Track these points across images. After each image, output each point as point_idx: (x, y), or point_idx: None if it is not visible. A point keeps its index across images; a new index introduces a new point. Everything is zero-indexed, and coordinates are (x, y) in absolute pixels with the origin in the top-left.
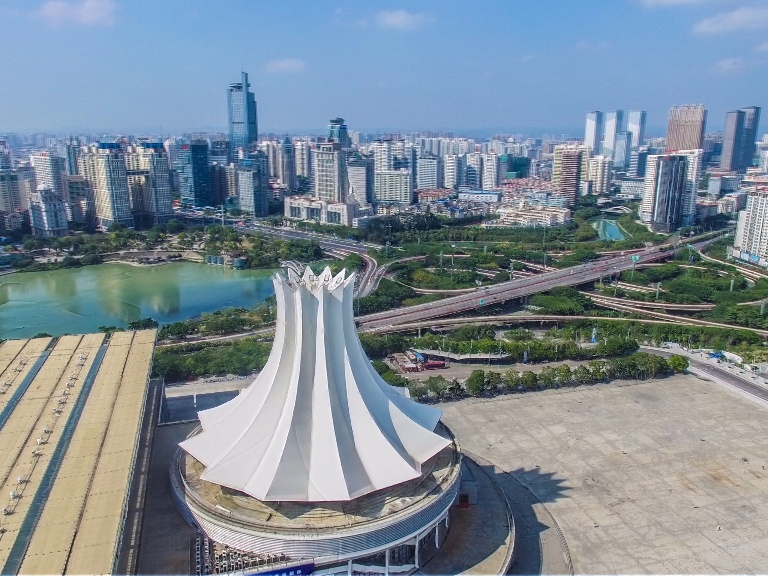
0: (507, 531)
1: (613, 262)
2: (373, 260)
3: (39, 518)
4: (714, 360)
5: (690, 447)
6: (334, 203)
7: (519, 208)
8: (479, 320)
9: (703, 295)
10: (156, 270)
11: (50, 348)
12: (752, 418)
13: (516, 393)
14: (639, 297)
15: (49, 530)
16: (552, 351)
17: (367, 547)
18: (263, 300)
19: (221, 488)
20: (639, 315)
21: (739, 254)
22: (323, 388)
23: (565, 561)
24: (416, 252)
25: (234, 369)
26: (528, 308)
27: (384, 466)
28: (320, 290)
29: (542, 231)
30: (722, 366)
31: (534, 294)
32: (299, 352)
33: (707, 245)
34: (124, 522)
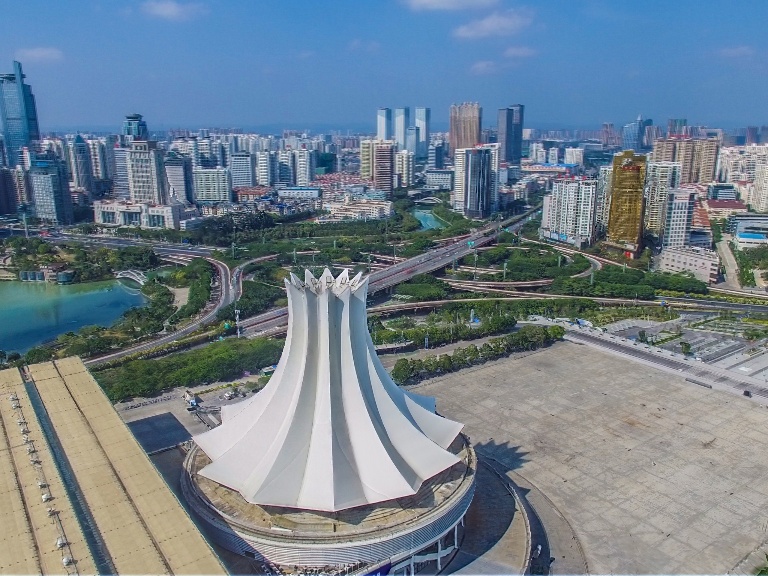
0: (512, 499)
1: (452, 248)
2: (221, 263)
3: None
4: (576, 326)
5: (599, 402)
6: (155, 206)
7: (345, 202)
8: None
9: (539, 272)
10: None
11: None
12: (630, 371)
13: (436, 376)
14: (490, 278)
15: None
16: (448, 334)
17: (433, 536)
18: (121, 315)
19: (265, 510)
20: (497, 294)
21: (550, 234)
22: (354, 390)
23: (558, 516)
24: (265, 252)
25: (143, 391)
26: (396, 297)
27: (424, 457)
28: (346, 292)
29: (373, 224)
30: (584, 331)
31: (399, 283)
32: (326, 357)
33: (518, 228)
34: None
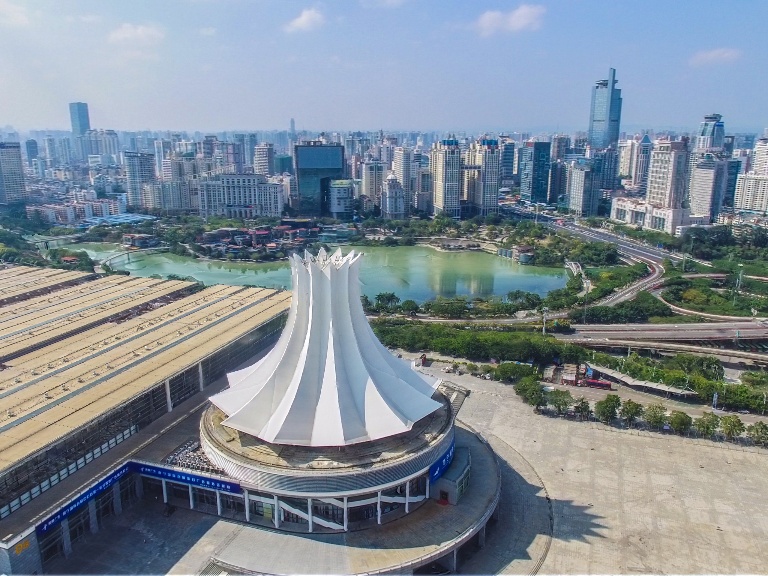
0: (454, 536)
1: None
2: (663, 272)
3: (89, 389)
4: None
5: None
6: (661, 208)
7: None
8: (719, 352)
9: None
10: (455, 256)
11: (234, 294)
12: None
13: (656, 432)
14: None
15: (84, 396)
16: (758, 401)
17: (280, 488)
18: (506, 294)
19: None
20: None
21: None
22: (305, 351)
23: None
24: (717, 269)
25: (402, 344)
26: None
27: (328, 429)
28: (309, 266)
29: None
30: None
31: None
32: None
33: None
34: (122, 405)
